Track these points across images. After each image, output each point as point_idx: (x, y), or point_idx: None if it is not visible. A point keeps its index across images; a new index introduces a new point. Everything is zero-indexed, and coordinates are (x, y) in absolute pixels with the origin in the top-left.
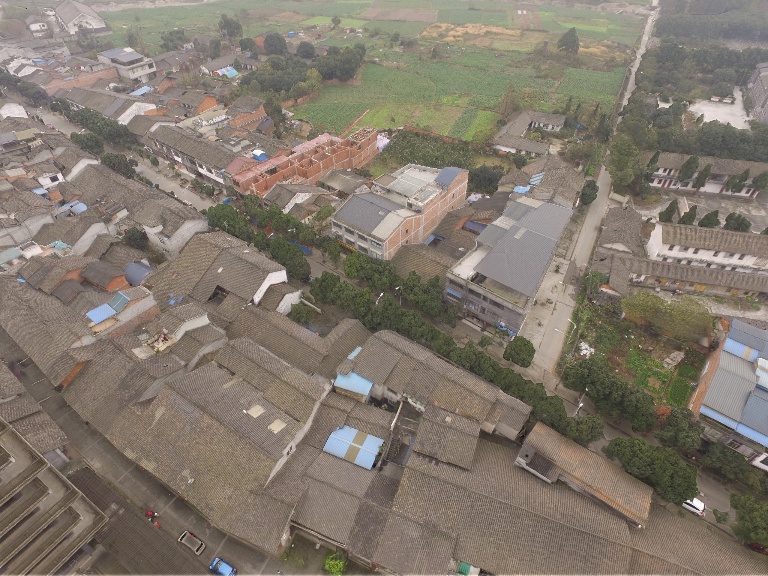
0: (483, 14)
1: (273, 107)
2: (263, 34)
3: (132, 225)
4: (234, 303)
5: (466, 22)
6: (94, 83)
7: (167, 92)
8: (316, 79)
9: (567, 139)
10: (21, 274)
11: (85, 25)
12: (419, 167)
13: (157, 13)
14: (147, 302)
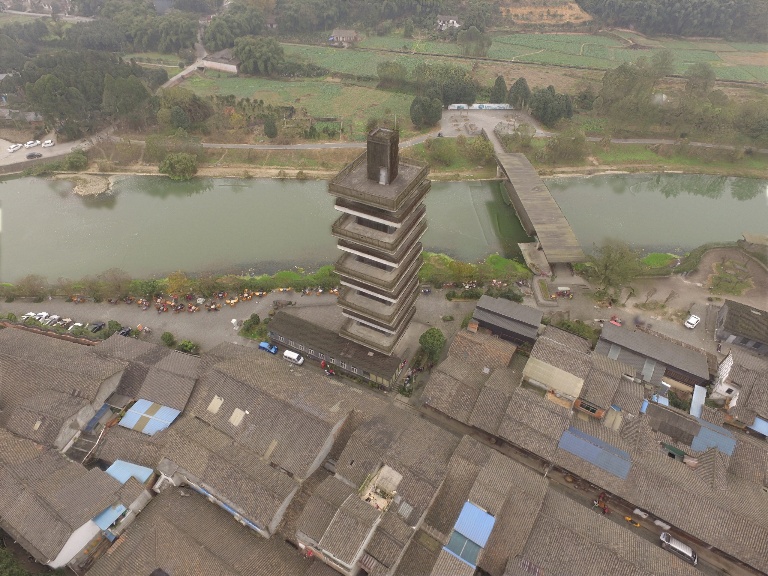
0: None
1: None
2: None
3: None
4: None
5: None
6: None
7: None
8: None
9: None
10: None
11: None
12: None
13: None
14: None
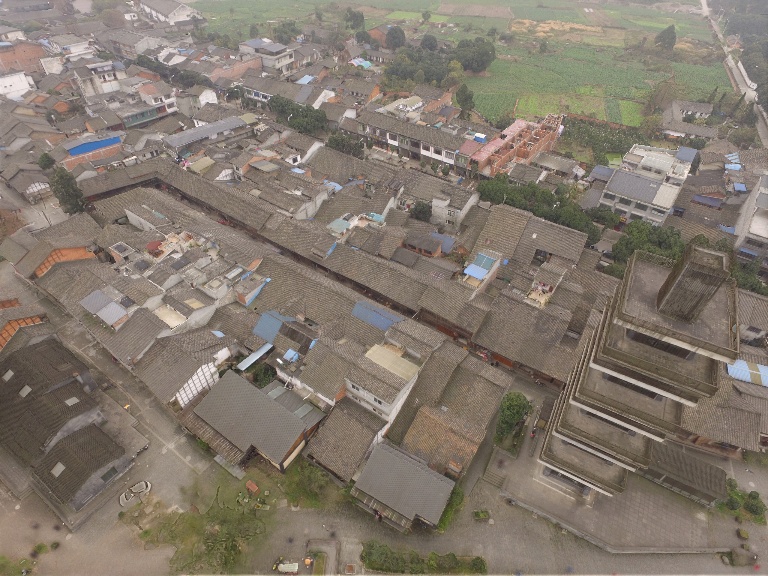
0: (555, 11)
1: (468, 94)
2: (378, 27)
3: (415, 200)
4: (561, 264)
5: (545, 19)
6: (244, 72)
7: (325, 81)
8: (461, 70)
9: (716, 125)
10: (352, 242)
11: (196, 16)
12: (644, 147)
13: (235, 5)
14: (497, 263)
